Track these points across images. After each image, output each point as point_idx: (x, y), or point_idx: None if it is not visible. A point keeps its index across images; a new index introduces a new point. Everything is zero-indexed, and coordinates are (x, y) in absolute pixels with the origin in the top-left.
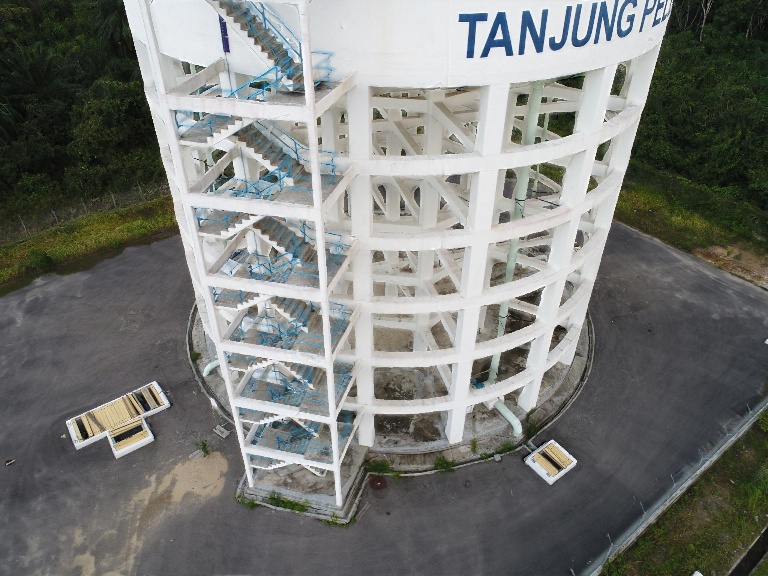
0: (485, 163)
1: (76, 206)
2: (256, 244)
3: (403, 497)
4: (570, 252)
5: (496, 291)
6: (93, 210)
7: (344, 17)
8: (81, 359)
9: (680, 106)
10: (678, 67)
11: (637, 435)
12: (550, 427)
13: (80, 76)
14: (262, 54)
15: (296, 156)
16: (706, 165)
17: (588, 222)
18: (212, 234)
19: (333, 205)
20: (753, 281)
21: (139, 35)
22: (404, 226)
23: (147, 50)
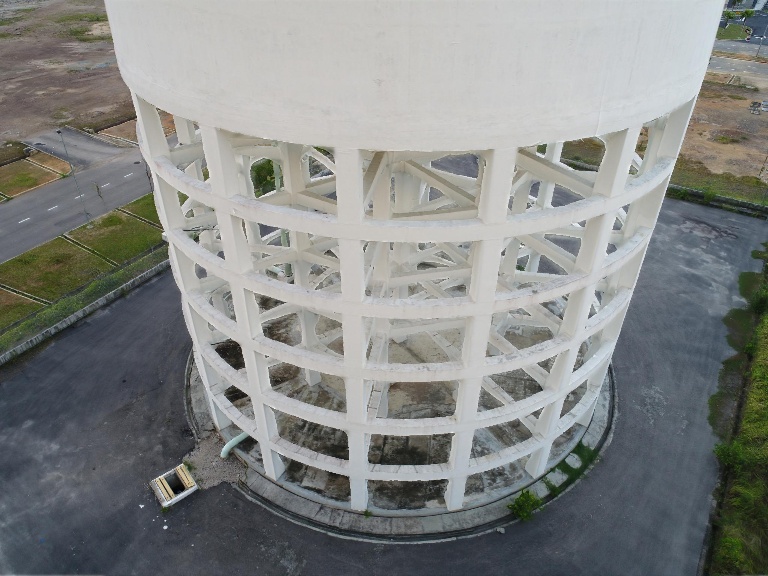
0: None
1: None
2: None
3: None
4: None
5: None
6: None
7: None
8: None
9: None
10: None
11: None
12: None
13: None
14: None
15: None
16: None
17: None
18: None
19: None
20: None
21: None
22: None
23: None
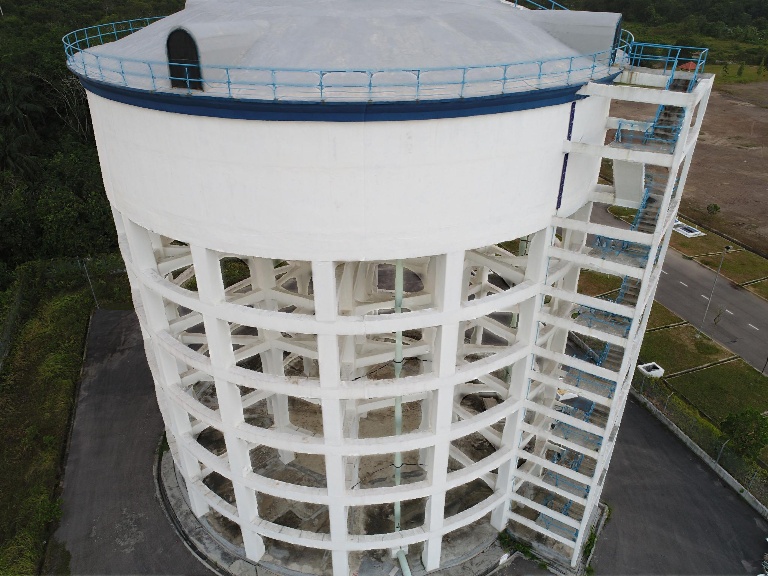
0: None
1: None
2: (532, 364)
3: None
4: None
5: None
6: None
7: None
8: None
9: None
10: None
11: None
12: None
13: None
14: None
15: None
16: None
17: None
18: None
19: None
20: None
21: (430, 250)
22: None
23: (447, 258)
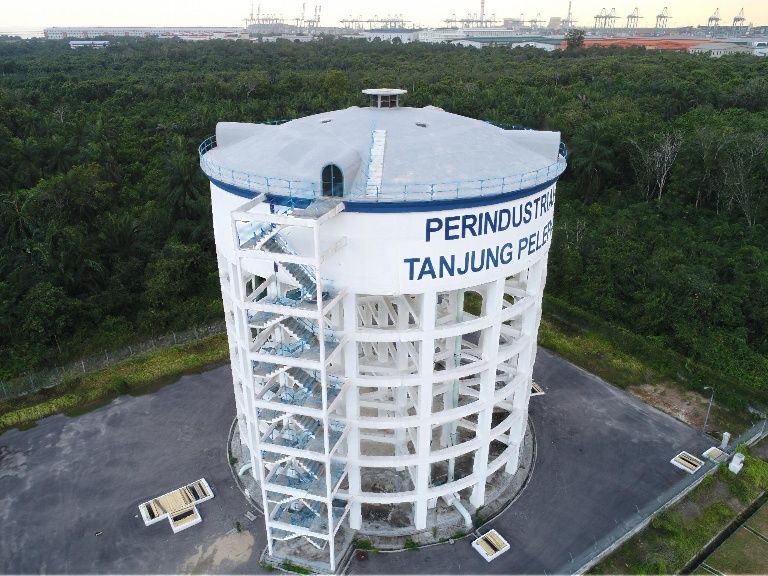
0: (425, 335)
1: (144, 342)
2: (285, 380)
3: (380, 567)
4: (493, 389)
5: (441, 415)
6: (157, 345)
7: (341, 259)
8: (149, 461)
9: (625, 269)
10: (638, 230)
11: (559, 528)
12: (494, 521)
13: (152, 238)
14: (296, 282)
15: (313, 329)
16: (642, 318)
17: (513, 368)
18: (261, 376)
19: (338, 353)
20: (671, 413)
21: (223, 253)
22: (386, 368)
23: None
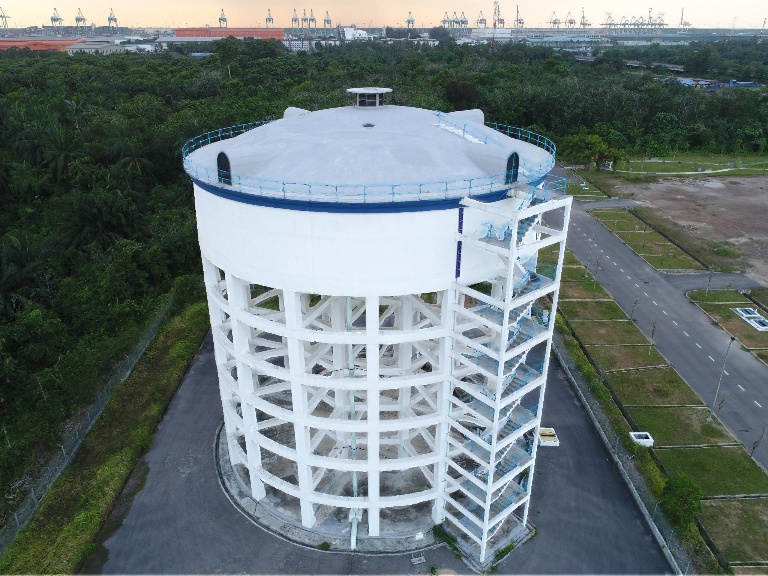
0: None
1: None
2: (450, 389)
3: (532, 501)
4: None
5: None
6: None
7: None
8: None
9: None
10: None
11: (549, 403)
12: None
13: None
14: (522, 268)
15: None
16: None
17: None
18: None
19: (409, 358)
20: None
21: (354, 293)
22: (438, 351)
23: (366, 300)
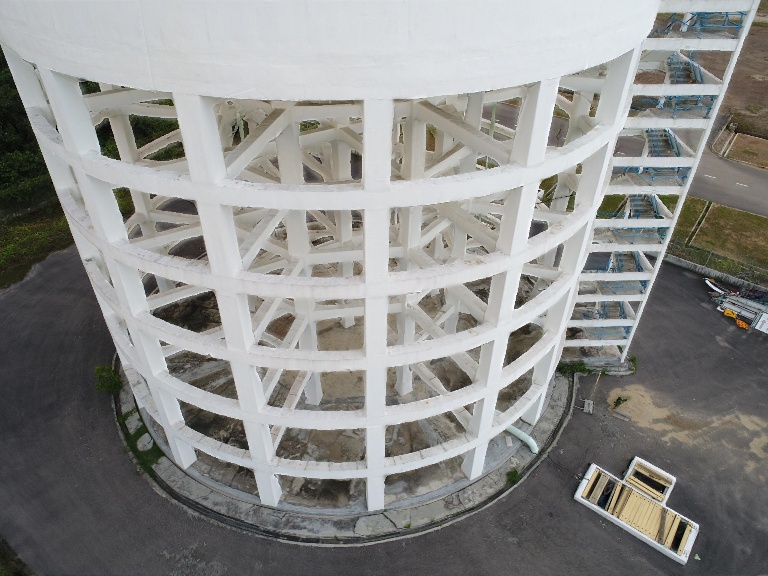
0: None
1: None
2: None
3: None
4: None
5: None
6: None
7: None
8: None
9: None
10: None
11: None
12: None
13: None
14: None
15: None
16: None
17: None
18: None
19: None
20: None
21: None
22: None
23: None
